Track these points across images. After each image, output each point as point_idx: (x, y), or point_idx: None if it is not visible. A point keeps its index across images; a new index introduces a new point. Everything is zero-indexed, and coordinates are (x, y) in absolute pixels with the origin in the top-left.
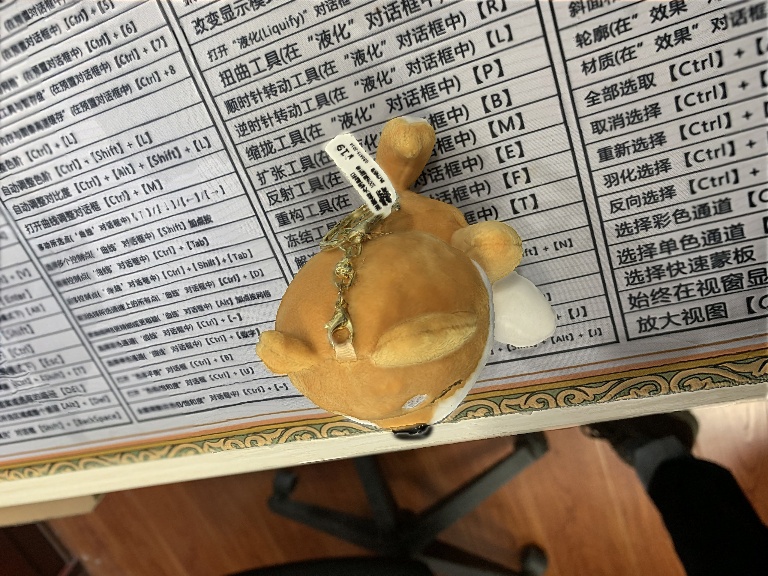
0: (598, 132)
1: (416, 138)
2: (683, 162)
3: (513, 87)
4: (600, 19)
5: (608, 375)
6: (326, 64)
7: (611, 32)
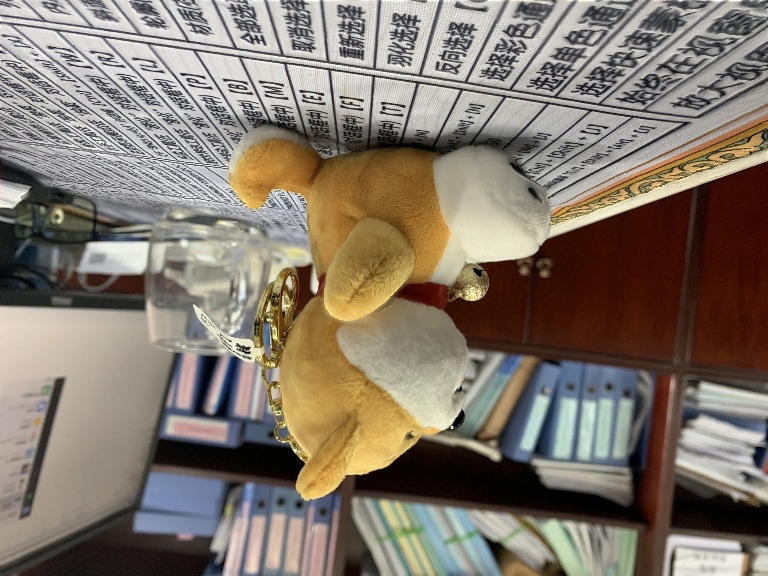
0: (311, 49)
1: (245, 195)
2: (412, 2)
3: (221, 76)
4: (121, 4)
5: (737, 135)
6: (177, 131)
7: (143, 1)
